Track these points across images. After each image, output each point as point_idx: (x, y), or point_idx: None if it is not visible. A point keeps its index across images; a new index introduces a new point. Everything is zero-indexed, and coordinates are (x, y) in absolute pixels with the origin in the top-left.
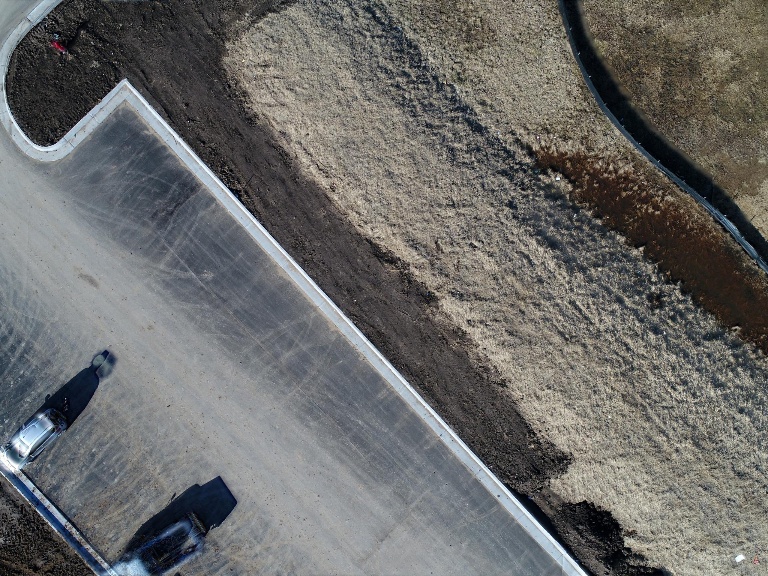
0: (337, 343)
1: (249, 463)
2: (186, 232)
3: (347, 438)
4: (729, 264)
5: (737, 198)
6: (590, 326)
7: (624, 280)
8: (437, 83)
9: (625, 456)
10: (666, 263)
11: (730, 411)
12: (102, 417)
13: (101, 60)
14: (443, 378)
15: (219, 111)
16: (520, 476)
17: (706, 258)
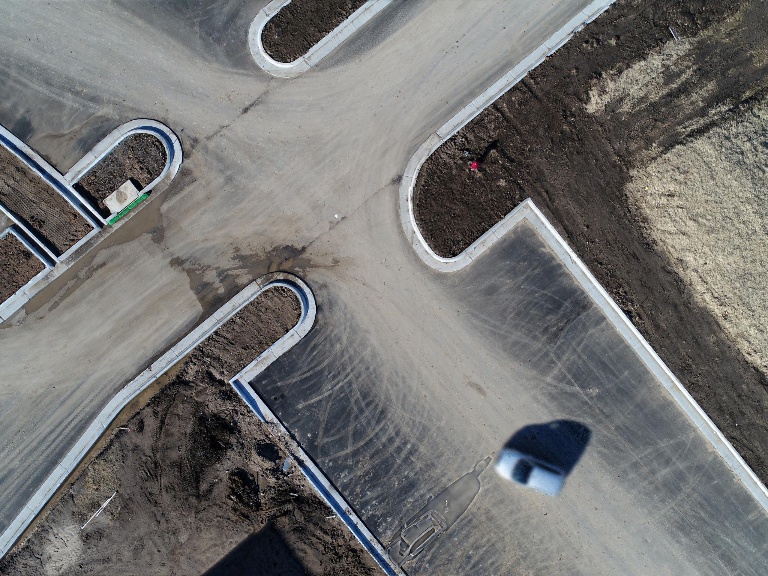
0: (713, 464)
1: (620, 574)
2: (575, 348)
3: (716, 555)
4: None
5: None
6: None
7: None
8: None
9: None
10: None
11: None
12: (480, 521)
13: (507, 179)
14: None
15: (618, 235)
16: None
17: None
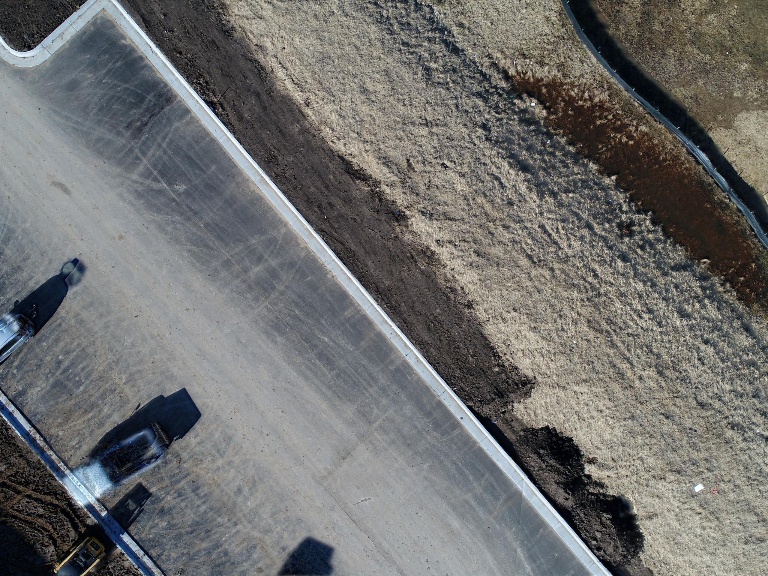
0: (306, 259)
1: (214, 376)
2: (160, 143)
3: (313, 355)
4: (701, 197)
5: (711, 131)
6: (559, 251)
7: (595, 207)
8: (415, 3)
9: (588, 381)
10: (638, 193)
11: (695, 341)
12: (70, 325)
13: None
14: (410, 298)
15: (197, 22)
16: (483, 398)
17: (678, 190)
